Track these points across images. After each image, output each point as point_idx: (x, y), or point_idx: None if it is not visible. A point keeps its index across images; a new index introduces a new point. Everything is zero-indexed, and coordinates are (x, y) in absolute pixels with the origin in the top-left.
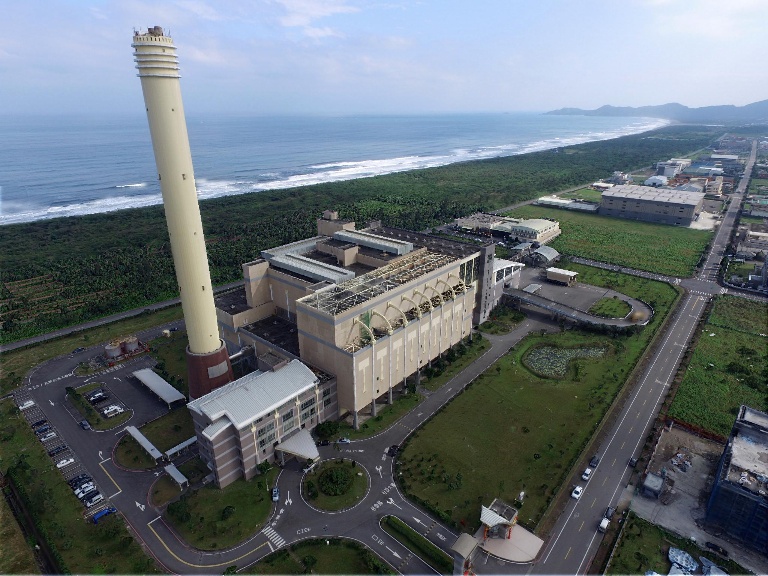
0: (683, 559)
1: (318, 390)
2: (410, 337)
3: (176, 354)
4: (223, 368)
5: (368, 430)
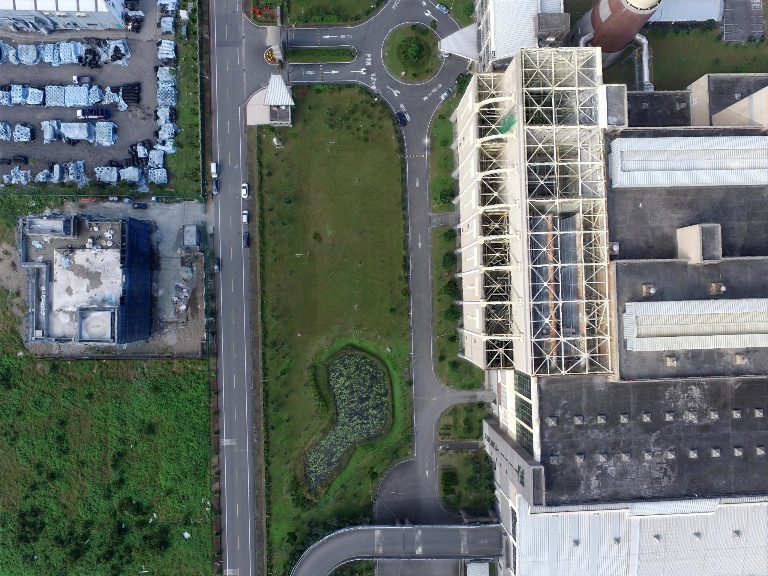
0: (157, 175)
1: (491, 64)
2: None
3: (735, 65)
4: (605, 12)
5: (441, 124)
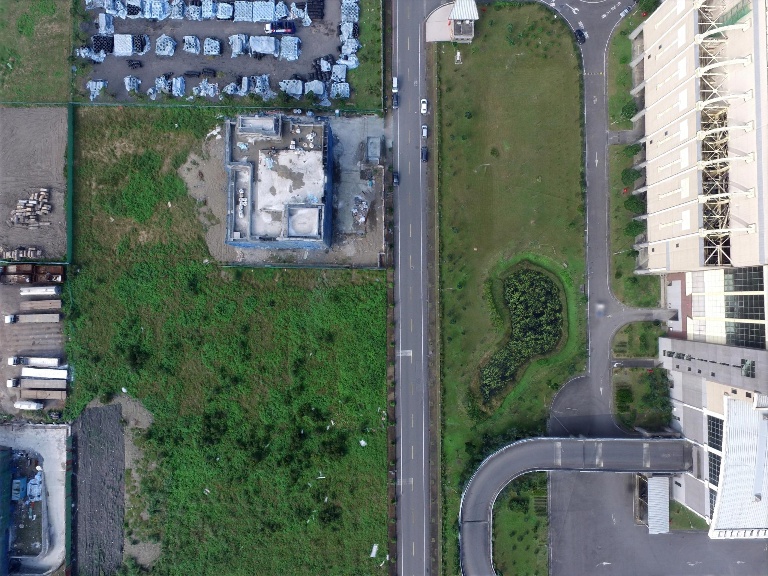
0: (340, 88)
1: None
2: (683, 97)
3: None
4: None
5: (620, 41)
